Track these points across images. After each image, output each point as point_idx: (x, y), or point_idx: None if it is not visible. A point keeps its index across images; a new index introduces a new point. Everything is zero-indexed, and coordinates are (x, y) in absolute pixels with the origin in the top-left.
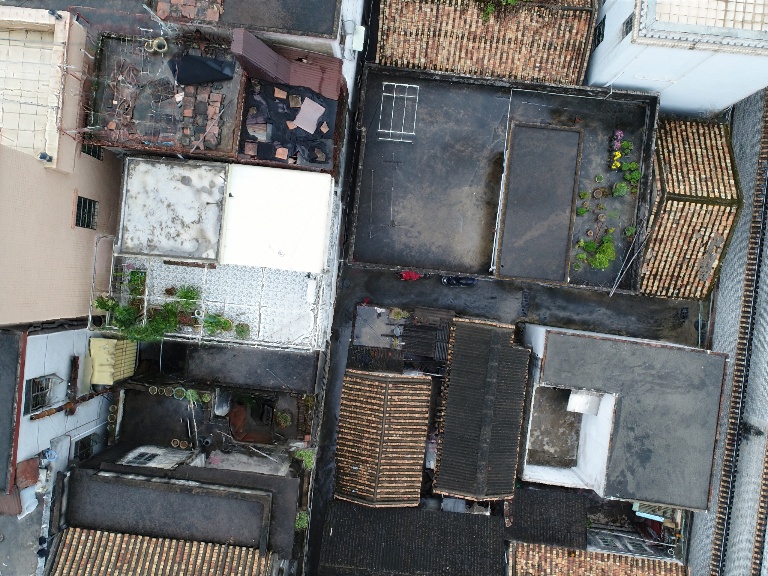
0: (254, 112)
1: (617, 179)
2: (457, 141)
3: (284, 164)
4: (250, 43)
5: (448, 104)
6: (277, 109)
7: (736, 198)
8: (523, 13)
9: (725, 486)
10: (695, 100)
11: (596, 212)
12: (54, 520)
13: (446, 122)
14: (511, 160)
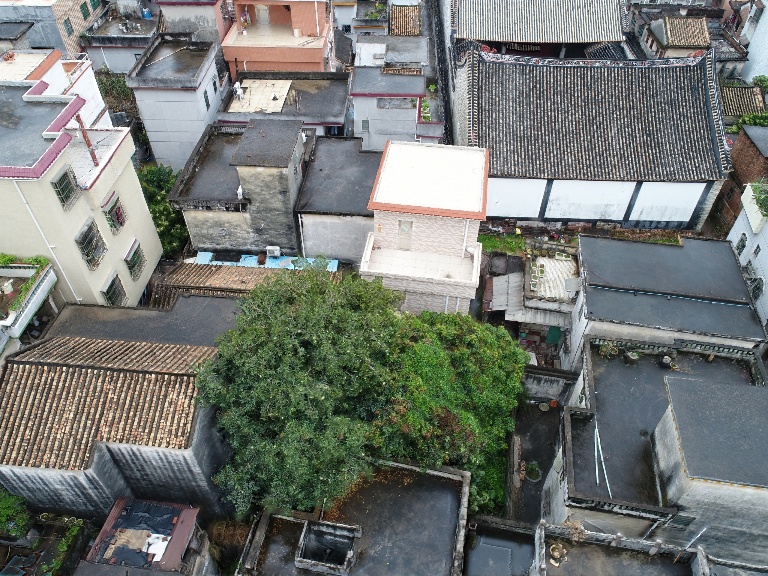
0: None
1: None
2: None
3: None
4: None
5: None
6: None
7: None
8: None
9: (439, 68)
10: (405, 4)
11: None
12: None
13: None
14: None
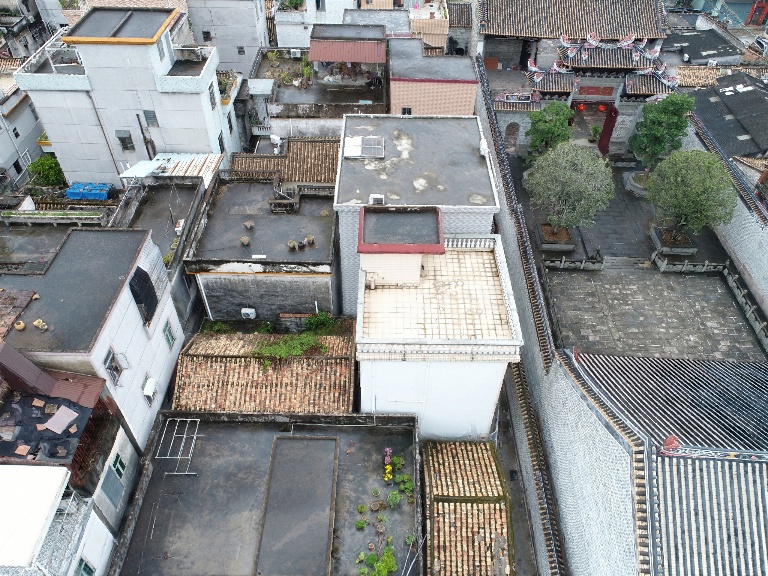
0: (7, 416)
1: None
2: (240, 470)
3: (23, 461)
4: (9, 354)
5: (235, 440)
6: (31, 414)
7: (502, 495)
8: (295, 364)
9: None
10: (457, 423)
11: (376, 525)
12: None
13: (231, 455)
14: (272, 467)
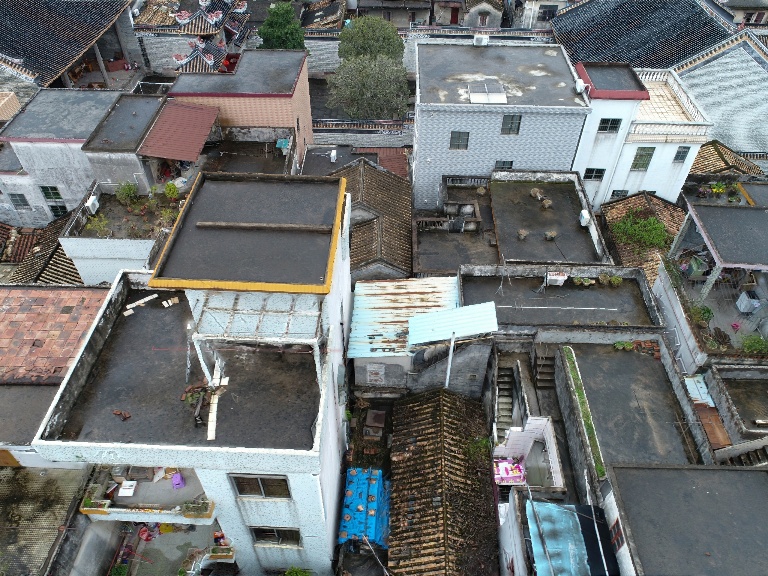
0: None
1: (725, 194)
2: None
3: None
4: None
5: None
6: None
7: (711, 145)
8: None
9: None
10: None
11: None
12: None
13: None
14: None
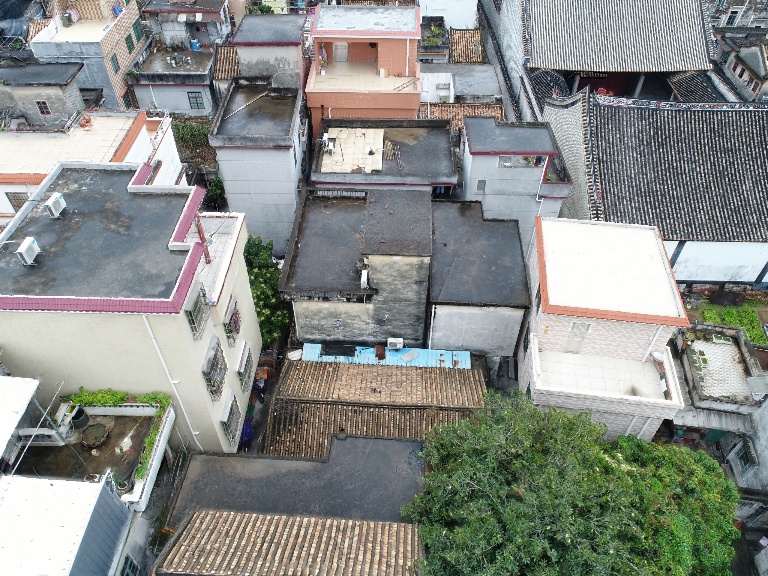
0: None
1: None
2: None
3: None
4: None
5: None
6: None
7: None
8: (391, 3)
9: (512, 101)
10: (460, 27)
11: None
12: (225, 40)
13: None
14: None
